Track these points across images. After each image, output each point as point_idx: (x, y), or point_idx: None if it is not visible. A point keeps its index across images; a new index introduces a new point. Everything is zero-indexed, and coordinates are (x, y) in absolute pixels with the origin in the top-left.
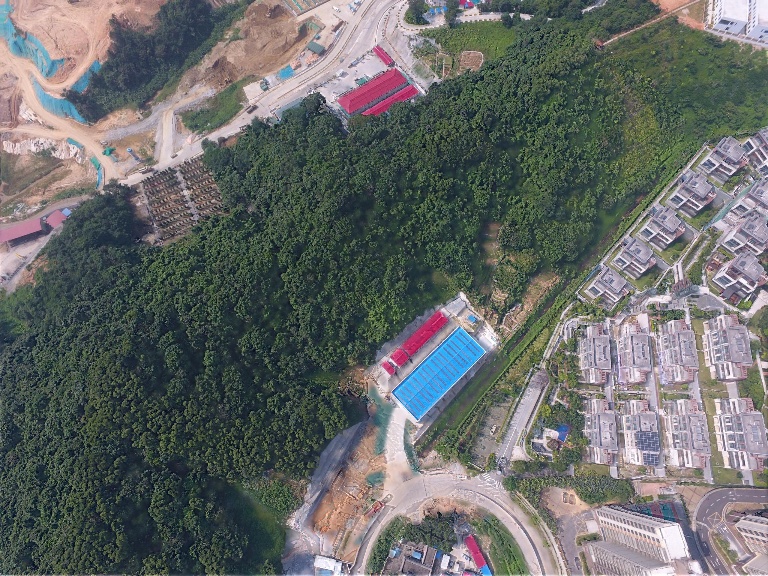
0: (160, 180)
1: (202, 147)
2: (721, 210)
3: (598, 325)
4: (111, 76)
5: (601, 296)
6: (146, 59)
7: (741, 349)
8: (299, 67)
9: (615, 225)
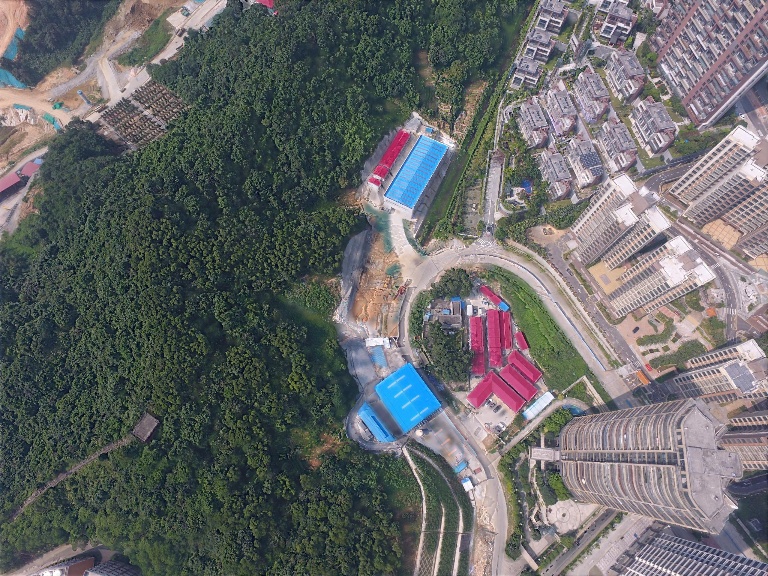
0: (118, 110)
1: (148, 72)
2: None
3: (528, 99)
4: (37, 39)
5: (524, 84)
6: (65, 18)
7: (633, 66)
8: None
9: (517, 33)
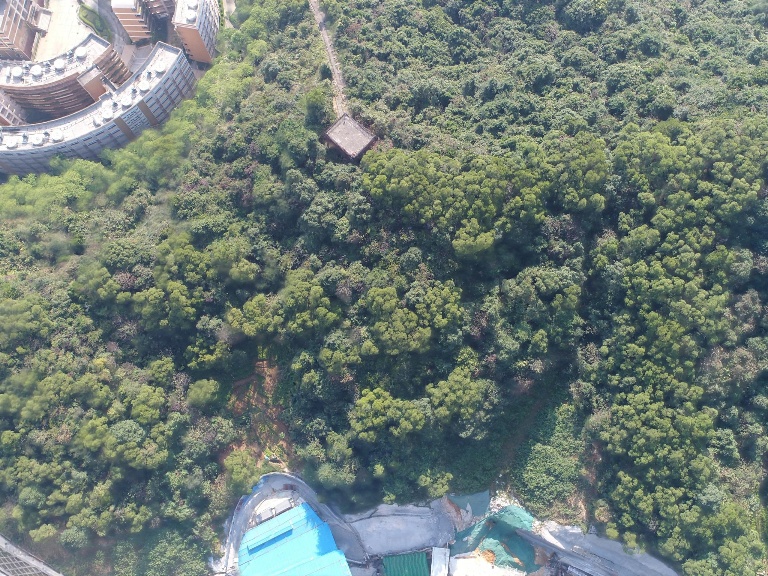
0: None
1: None
2: None
3: None
4: None
5: None
6: None
7: None
8: None
9: None
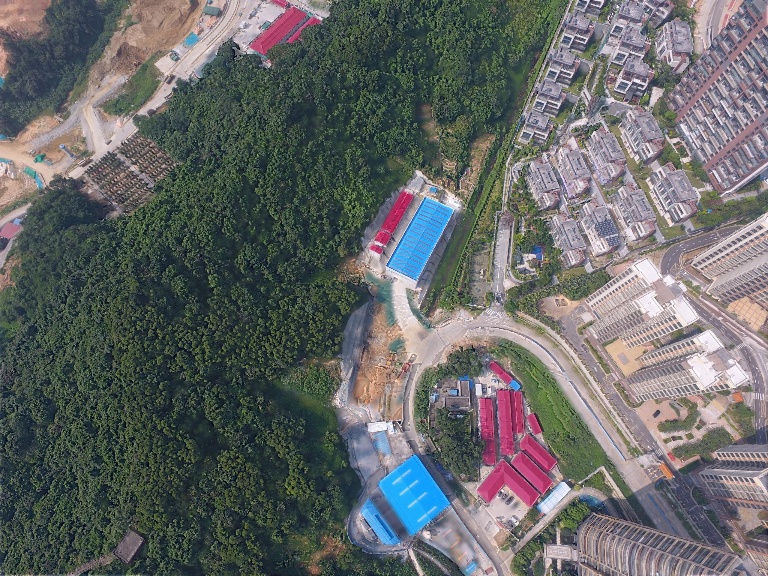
0: (103, 165)
1: (134, 124)
2: (603, 38)
3: (538, 158)
4: (18, 87)
5: (533, 139)
6: (47, 63)
7: (652, 129)
8: (202, 32)
9: (525, 82)
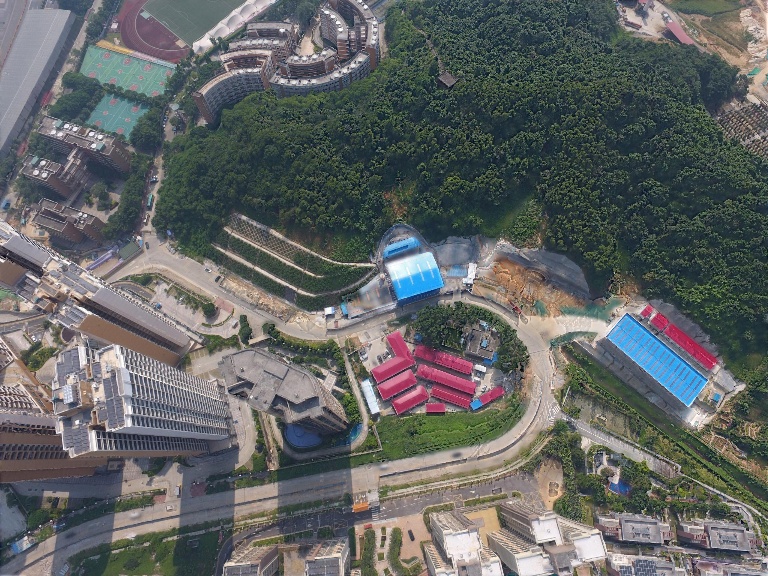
0: (762, 116)
1: None
2: None
3: None
4: None
5: None
6: None
7: None
8: None
9: None
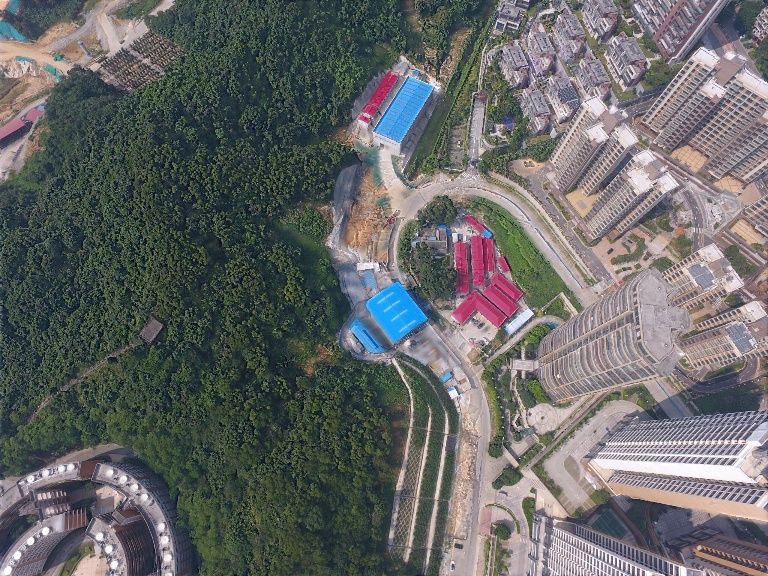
0: (118, 59)
1: (145, 23)
2: None
3: (509, 41)
4: None
5: (506, 29)
6: None
7: (608, 4)
8: None
9: None
